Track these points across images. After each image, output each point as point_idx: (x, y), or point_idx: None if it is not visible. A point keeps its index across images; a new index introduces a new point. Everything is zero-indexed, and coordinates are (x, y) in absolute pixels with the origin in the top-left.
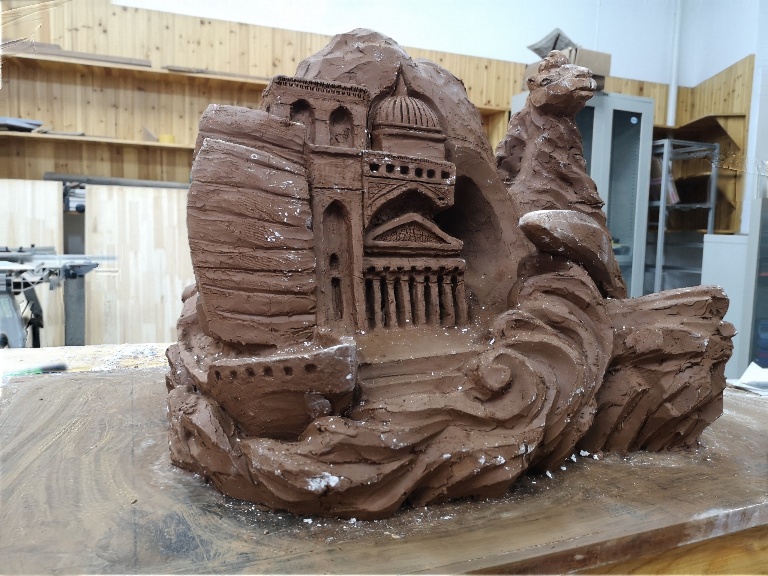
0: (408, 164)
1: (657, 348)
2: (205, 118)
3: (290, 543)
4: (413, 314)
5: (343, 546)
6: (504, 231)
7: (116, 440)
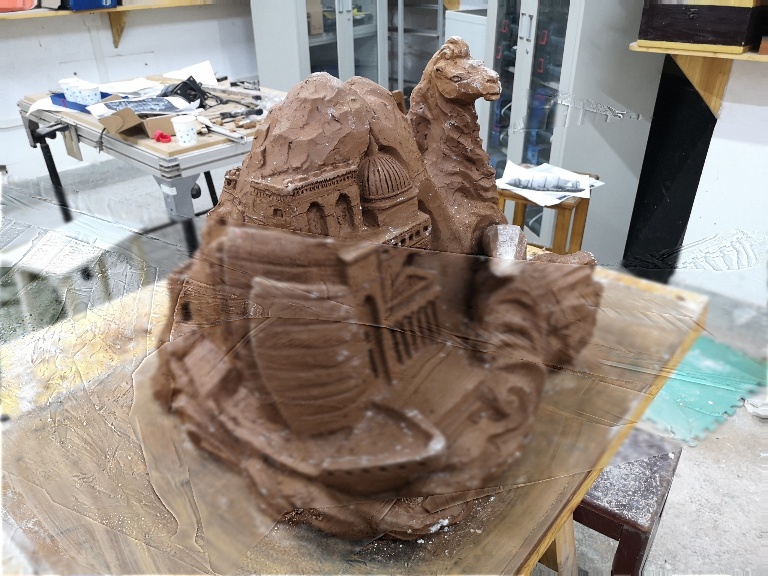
0: (405, 236)
1: None
2: None
3: (428, 568)
4: None
5: (459, 555)
6: (442, 230)
7: None
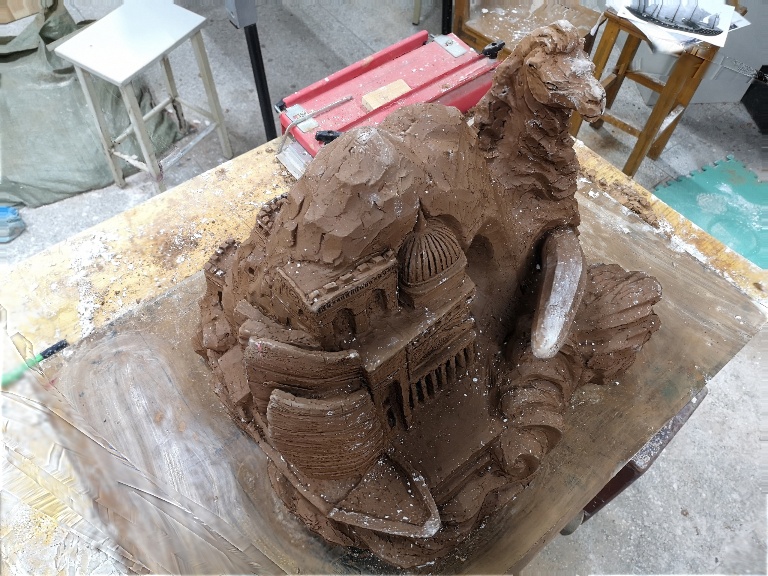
0: None
1: None
2: (252, 359)
3: None
4: (437, 379)
5: None
6: (496, 251)
7: (224, 482)
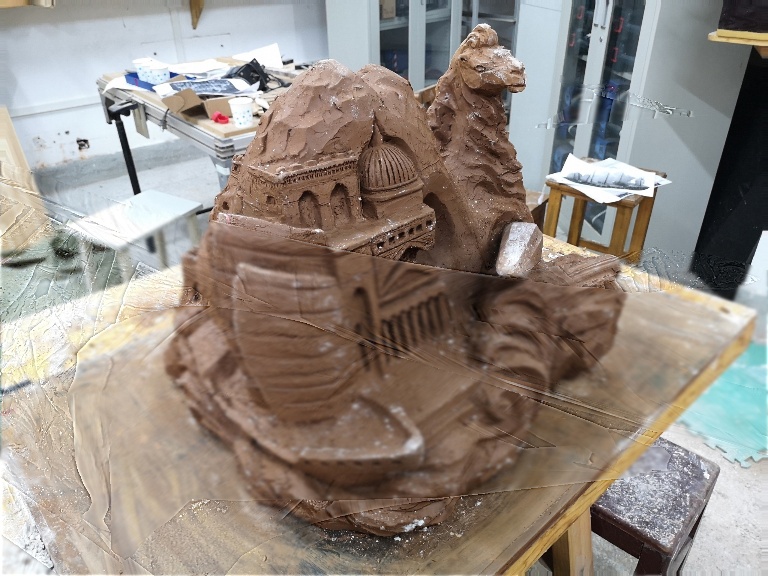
0: (404, 230)
1: None
2: None
3: (400, 566)
4: None
5: (434, 557)
6: (456, 225)
7: None
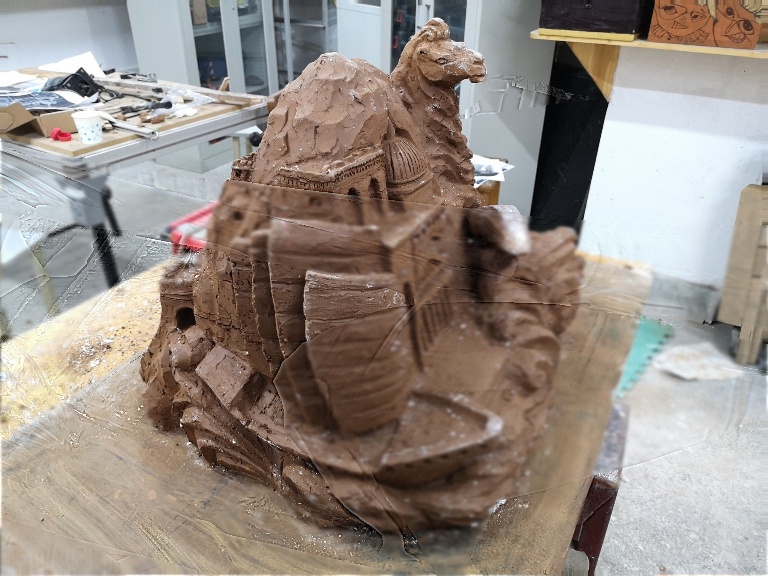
0: None
1: None
2: None
3: None
4: None
5: None
6: None
7: None
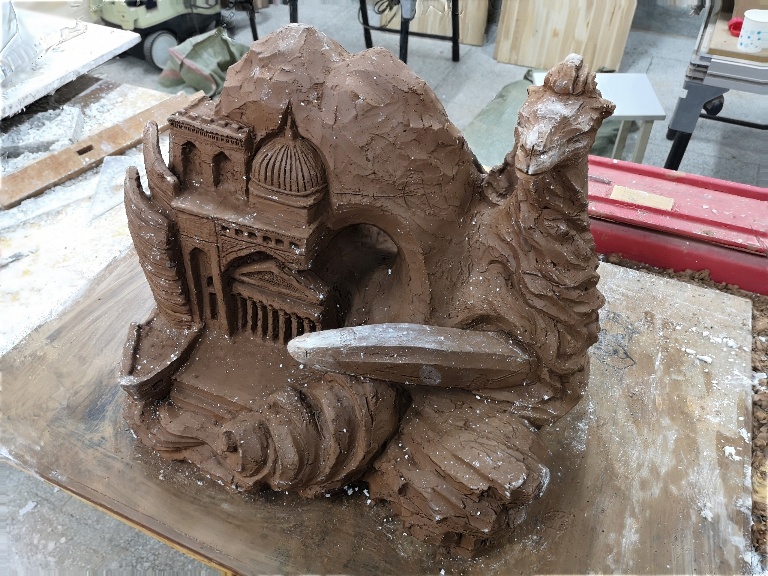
0: (255, 232)
1: (392, 490)
2: None
3: (124, 445)
4: None
5: (135, 466)
6: (413, 280)
7: None
